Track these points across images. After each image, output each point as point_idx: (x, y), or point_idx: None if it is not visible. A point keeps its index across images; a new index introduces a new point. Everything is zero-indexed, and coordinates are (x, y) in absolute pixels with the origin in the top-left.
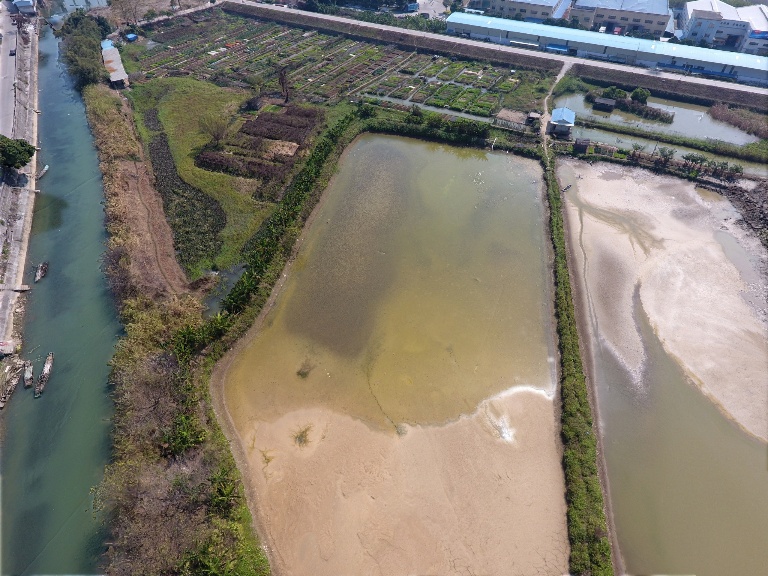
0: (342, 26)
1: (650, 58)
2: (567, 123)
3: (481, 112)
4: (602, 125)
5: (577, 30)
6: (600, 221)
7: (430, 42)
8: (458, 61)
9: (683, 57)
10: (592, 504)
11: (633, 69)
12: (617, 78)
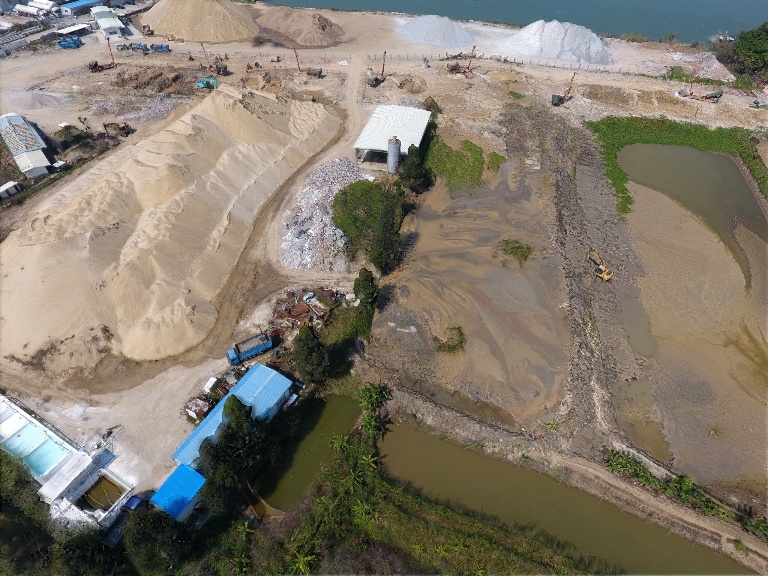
0: None
1: None
2: None
3: None
4: None
5: None
6: None
7: None
8: None
9: None
10: (760, 168)
11: None
12: None
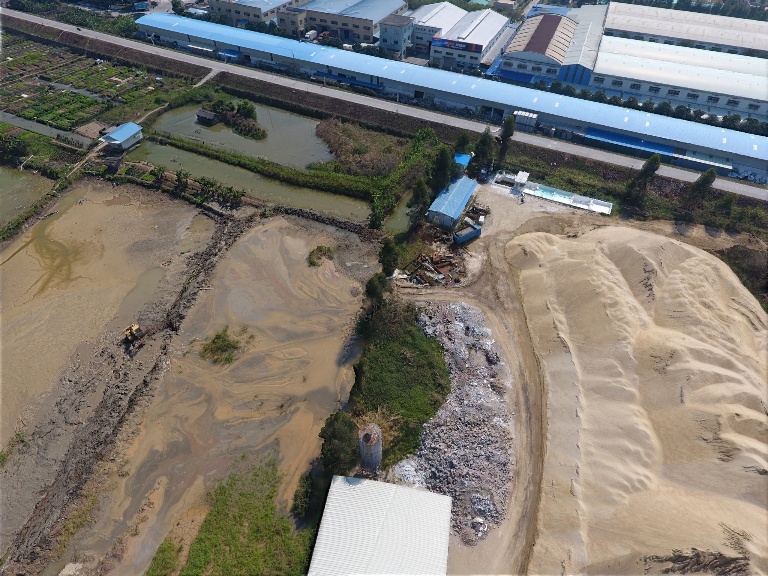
0: (28, 26)
1: (310, 66)
2: (114, 140)
3: (61, 125)
4: (173, 141)
5: (258, 34)
6: (34, 255)
7: (100, 45)
8: (119, 66)
9: (334, 66)
10: None
11: (275, 78)
12: (253, 88)
